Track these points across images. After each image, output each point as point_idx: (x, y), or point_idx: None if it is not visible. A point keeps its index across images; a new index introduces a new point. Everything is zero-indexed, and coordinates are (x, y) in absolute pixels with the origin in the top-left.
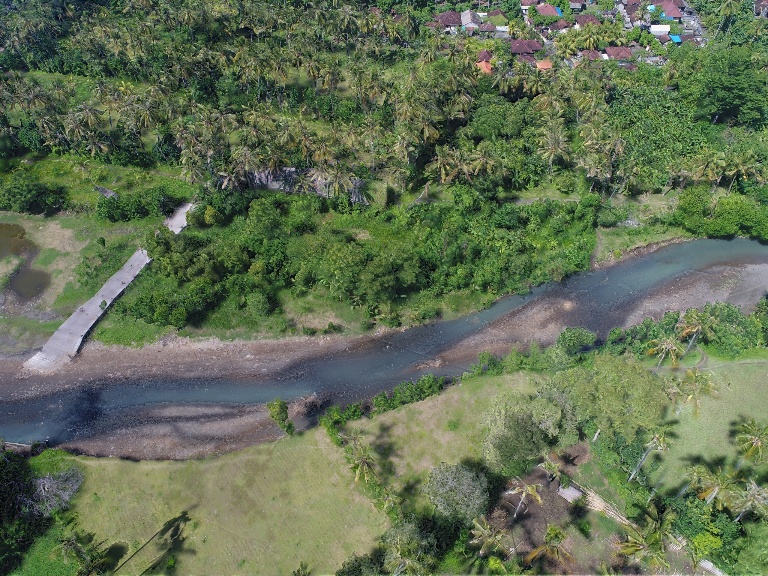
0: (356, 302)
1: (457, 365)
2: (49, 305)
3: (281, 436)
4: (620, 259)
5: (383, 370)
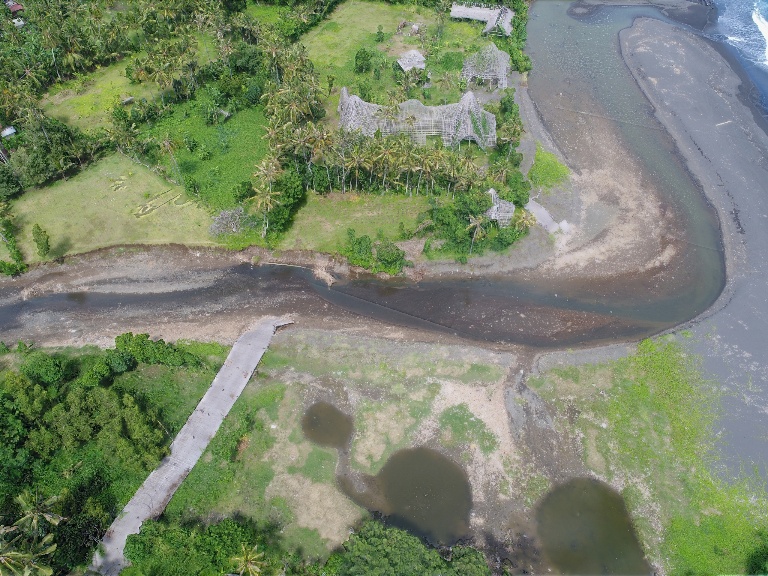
0: None
1: None
2: (290, 388)
3: (63, 267)
4: None
5: None
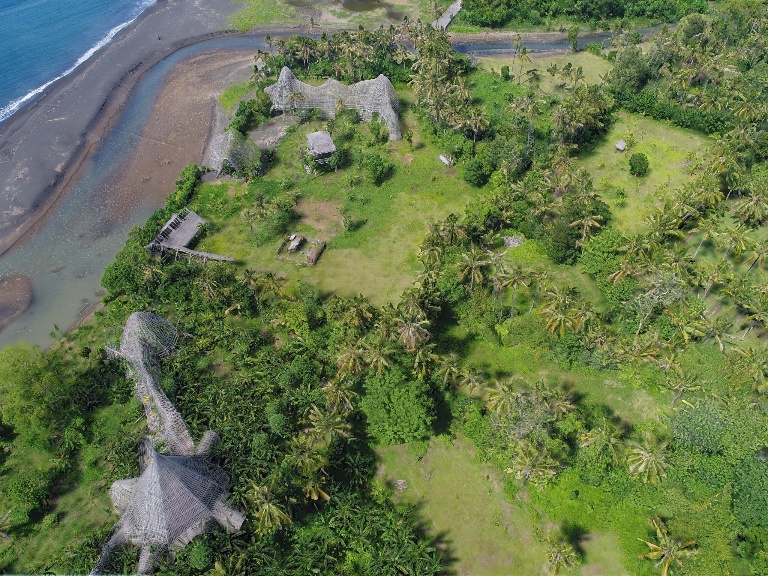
0: (586, 18)
1: (644, 41)
2: None
3: None
4: (722, 13)
5: (606, 42)
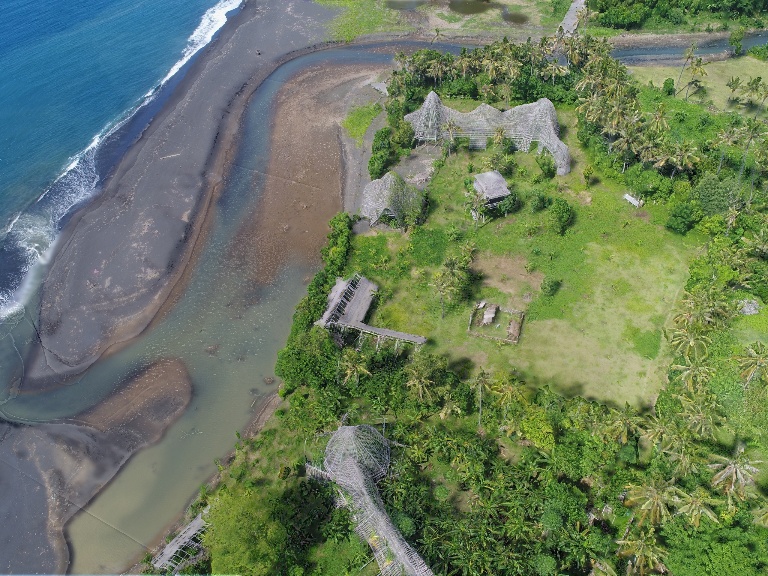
0: (735, 15)
1: None
2: (538, 24)
3: None
4: None
5: (764, 43)
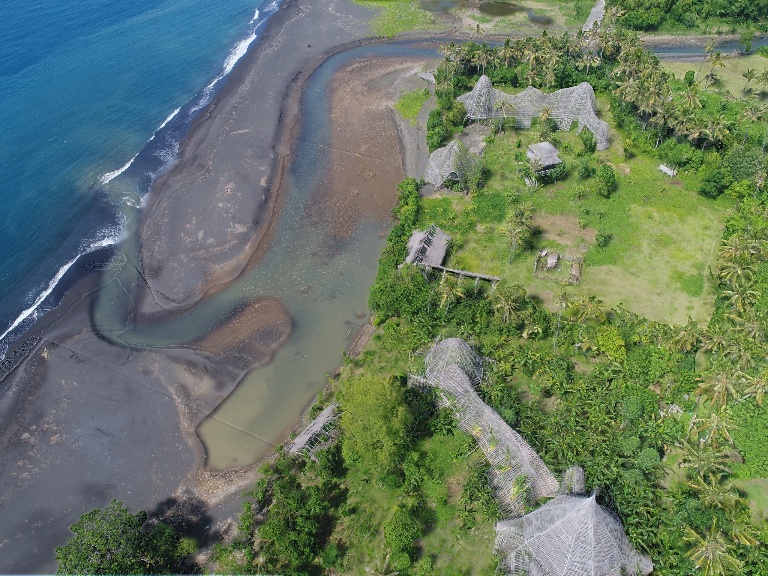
0: (742, 20)
1: None
2: (563, 25)
3: None
4: None
5: None
